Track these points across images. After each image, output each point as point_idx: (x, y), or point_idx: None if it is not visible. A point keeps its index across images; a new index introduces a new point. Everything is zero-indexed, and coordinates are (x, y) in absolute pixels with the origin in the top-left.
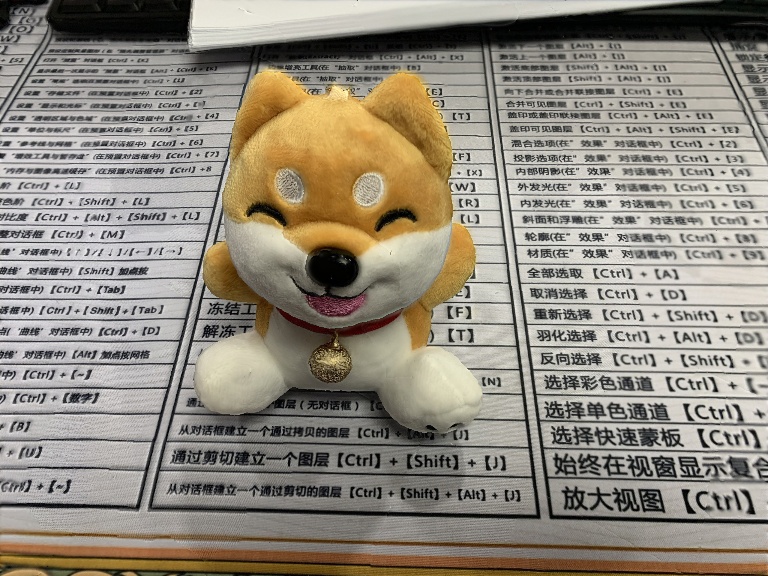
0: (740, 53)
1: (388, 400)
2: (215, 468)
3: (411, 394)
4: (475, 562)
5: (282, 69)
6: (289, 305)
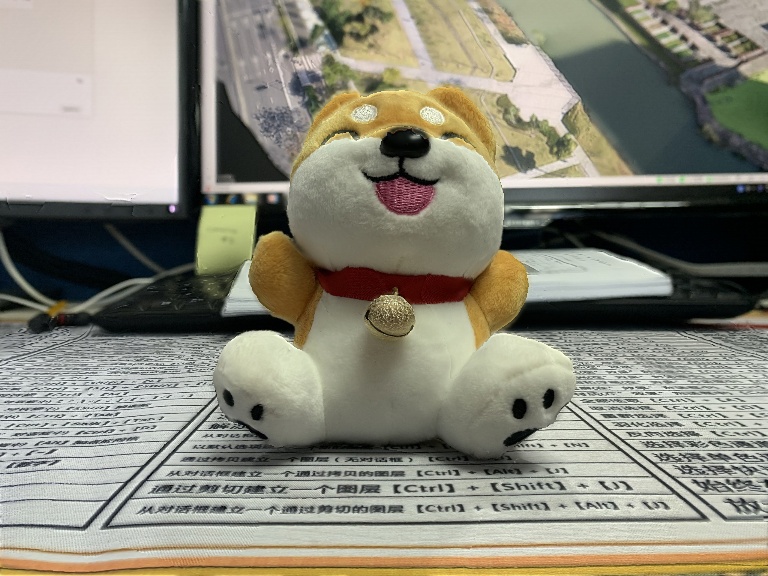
0: (706, 334)
1: (457, 396)
2: (214, 495)
3: (487, 363)
4: (637, 559)
5: None
6: (356, 207)
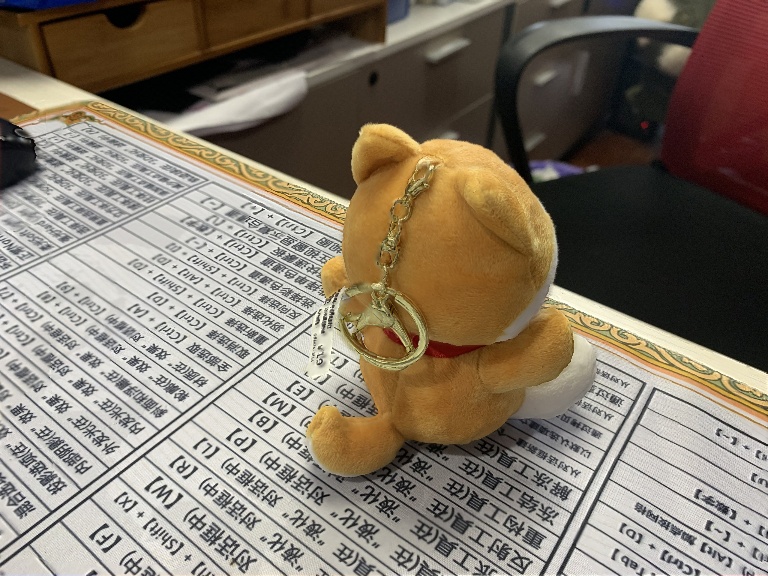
0: None
1: None
2: None
3: None
4: None
5: None
6: None
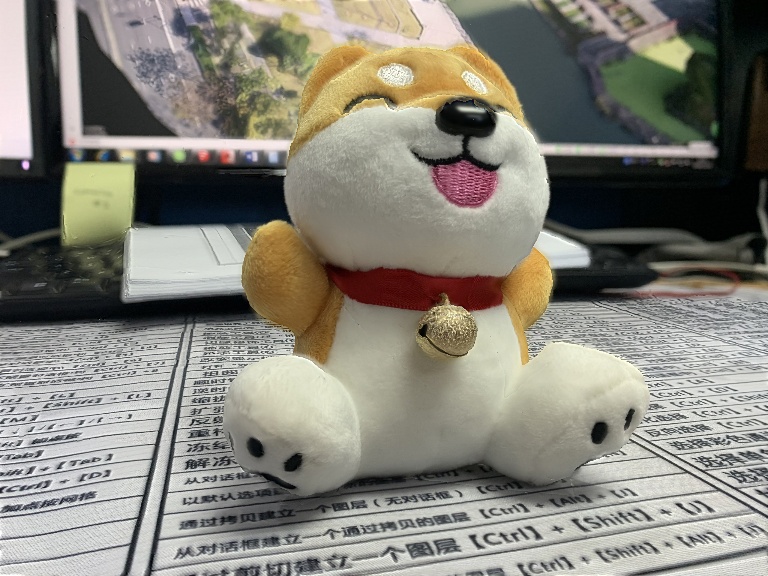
0: (619, 303)
1: (520, 420)
2: None
3: (557, 381)
4: None
5: (221, 325)
6: (408, 196)
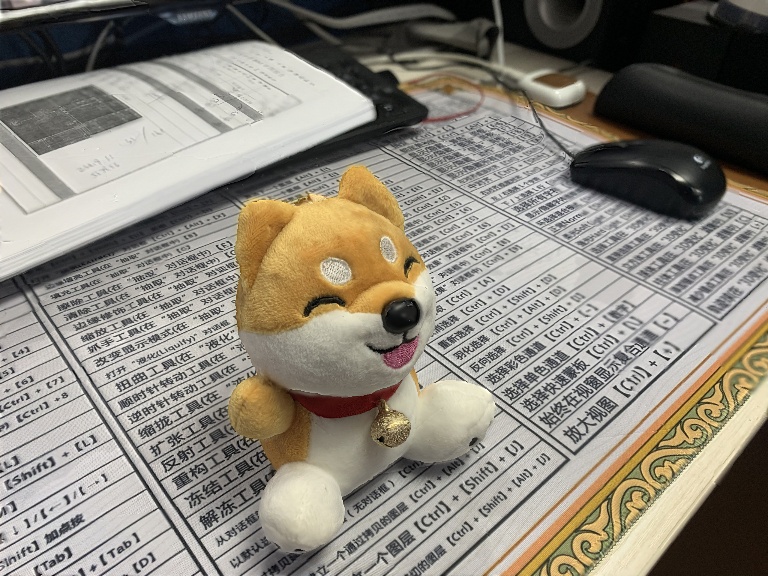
0: (401, 148)
1: (429, 445)
2: None
3: (449, 421)
4: (566, 517)
5: (63, 284)
6: (368, 376)
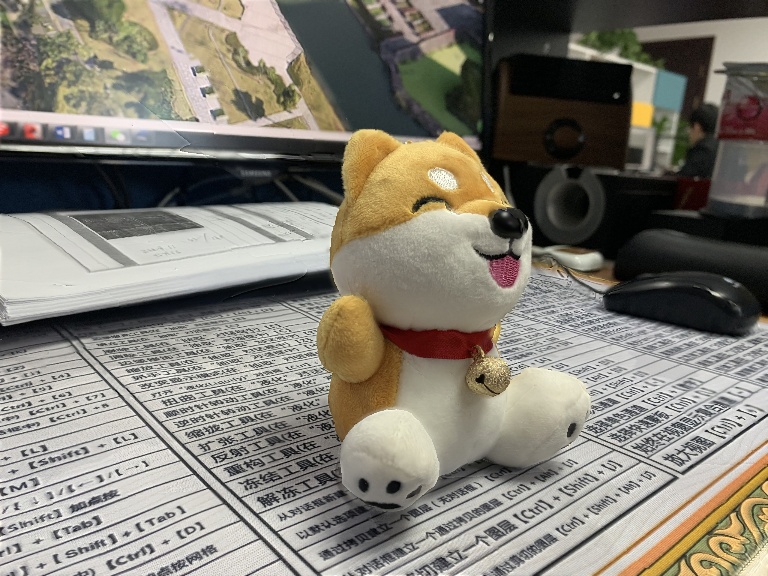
0: None
1: (522, 428)
2: None
3: (545, 398)
4: (692, 521)
5: (110, 338)
6: (474, 283)
